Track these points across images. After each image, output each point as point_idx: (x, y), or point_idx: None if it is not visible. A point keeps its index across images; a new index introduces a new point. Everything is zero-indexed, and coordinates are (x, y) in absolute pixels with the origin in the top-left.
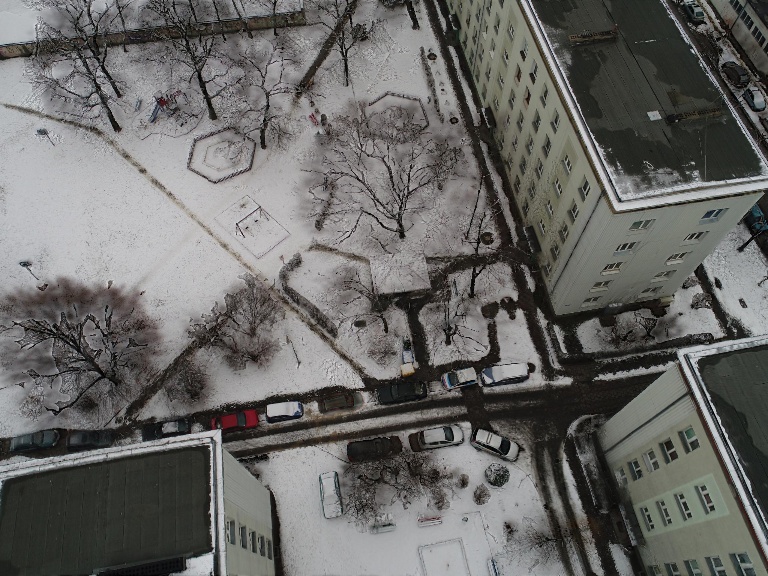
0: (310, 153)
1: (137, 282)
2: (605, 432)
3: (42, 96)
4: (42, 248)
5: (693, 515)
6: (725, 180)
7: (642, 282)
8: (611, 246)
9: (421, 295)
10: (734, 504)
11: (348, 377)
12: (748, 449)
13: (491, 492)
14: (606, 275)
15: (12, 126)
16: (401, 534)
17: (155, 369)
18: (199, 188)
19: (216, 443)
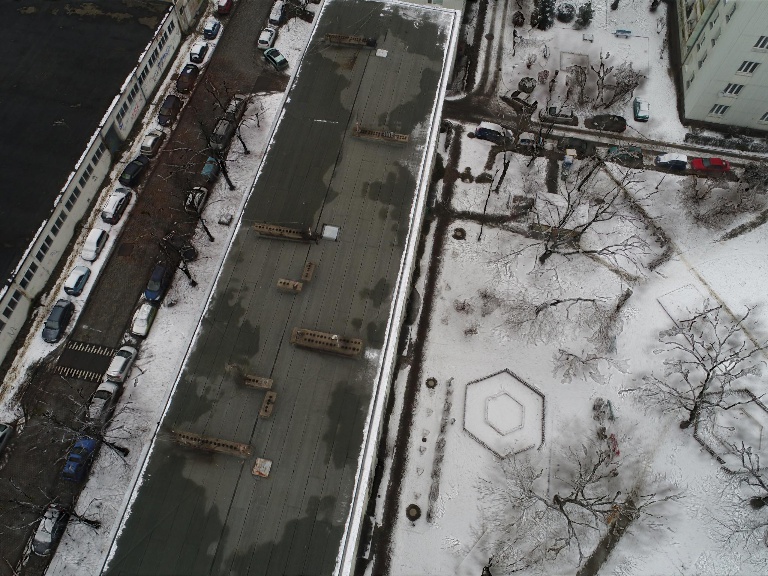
0: (624, 396)
1: None
2: None
3: None
4: None
5: None
6: None
7: None
8: None
9: None
10: None
11: (617, 169)
12: None
13: None
14: None
15: None
16: None
17: None
18: (764, 392)
19: None
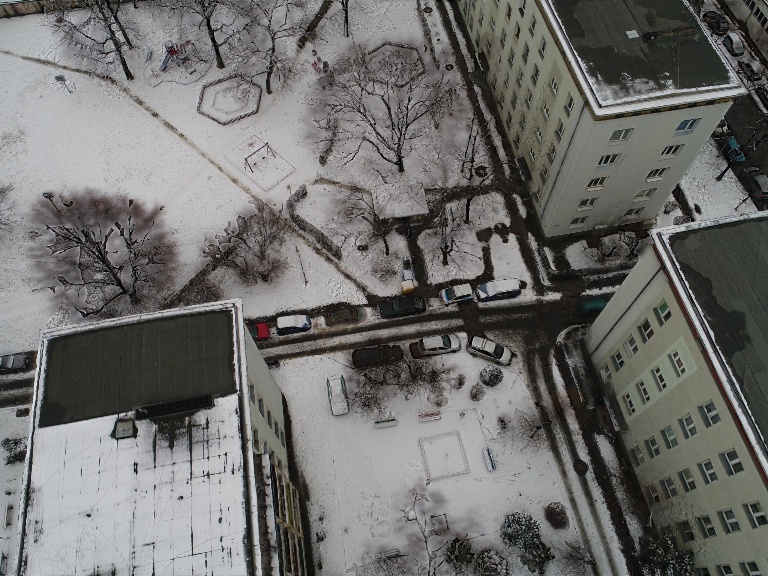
0: (313, 97)
1: (153, 213)
2: (591, 335)
3: (57, 49)
4: (62, 184)
5: (667, 383)
6: (696, 88)
7: (625, 201)
8: (594, 158)
9: (420, 222)
10: (701, 358)
11: (352, 294)
12: (712, 307)
13: (486, 392)
14: (591, 191)
15: (30, 76)
16: (403, 429)
17: (172, 289)
18: (209, 130)
19: (238, 308)
